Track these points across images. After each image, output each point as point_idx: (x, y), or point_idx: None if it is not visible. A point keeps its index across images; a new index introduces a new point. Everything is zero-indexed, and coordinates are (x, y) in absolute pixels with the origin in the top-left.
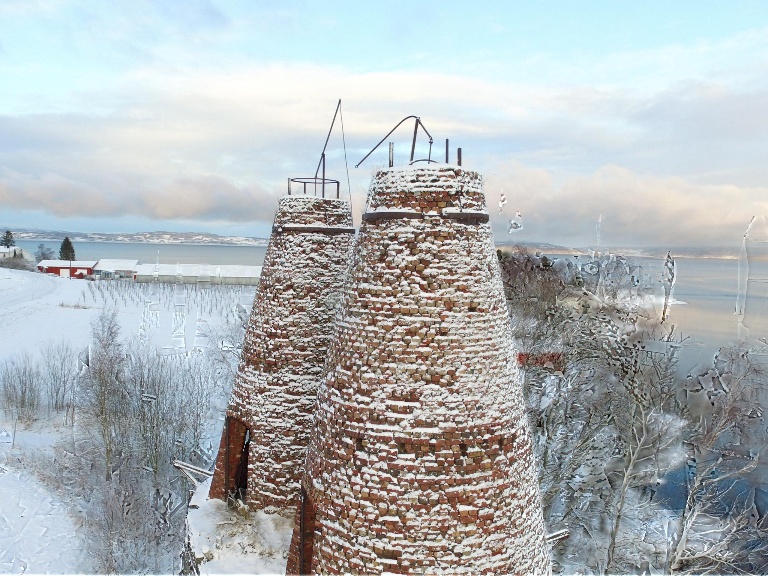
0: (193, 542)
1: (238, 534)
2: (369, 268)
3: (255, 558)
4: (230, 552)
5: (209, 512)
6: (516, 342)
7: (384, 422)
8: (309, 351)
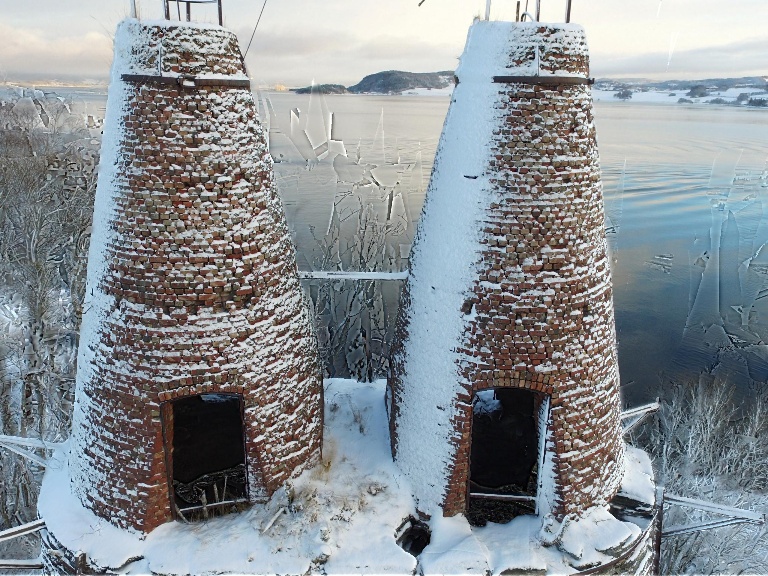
0: (251, 575)
1: (319, 513)
2: (564, 139)
3: (361, 517)
4: (341, 532)
5: (193, 541)
6: (7, 213)
7: (595, 283)
8: (282, 261)
